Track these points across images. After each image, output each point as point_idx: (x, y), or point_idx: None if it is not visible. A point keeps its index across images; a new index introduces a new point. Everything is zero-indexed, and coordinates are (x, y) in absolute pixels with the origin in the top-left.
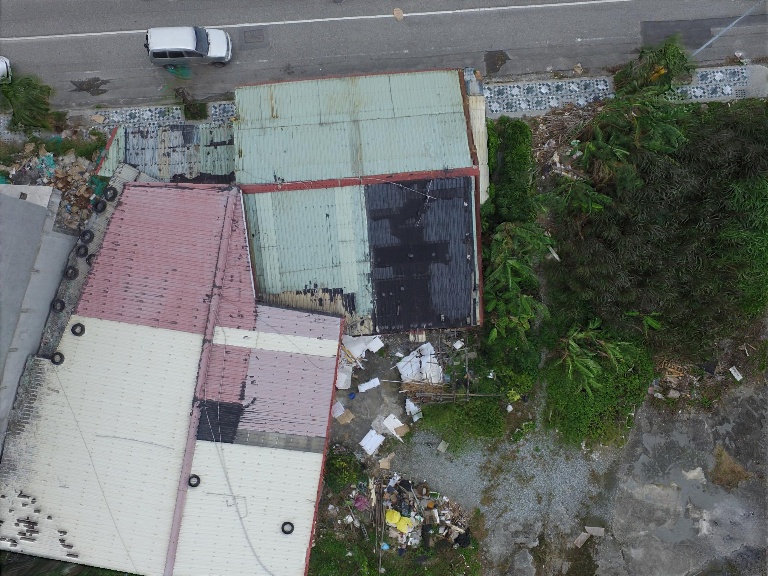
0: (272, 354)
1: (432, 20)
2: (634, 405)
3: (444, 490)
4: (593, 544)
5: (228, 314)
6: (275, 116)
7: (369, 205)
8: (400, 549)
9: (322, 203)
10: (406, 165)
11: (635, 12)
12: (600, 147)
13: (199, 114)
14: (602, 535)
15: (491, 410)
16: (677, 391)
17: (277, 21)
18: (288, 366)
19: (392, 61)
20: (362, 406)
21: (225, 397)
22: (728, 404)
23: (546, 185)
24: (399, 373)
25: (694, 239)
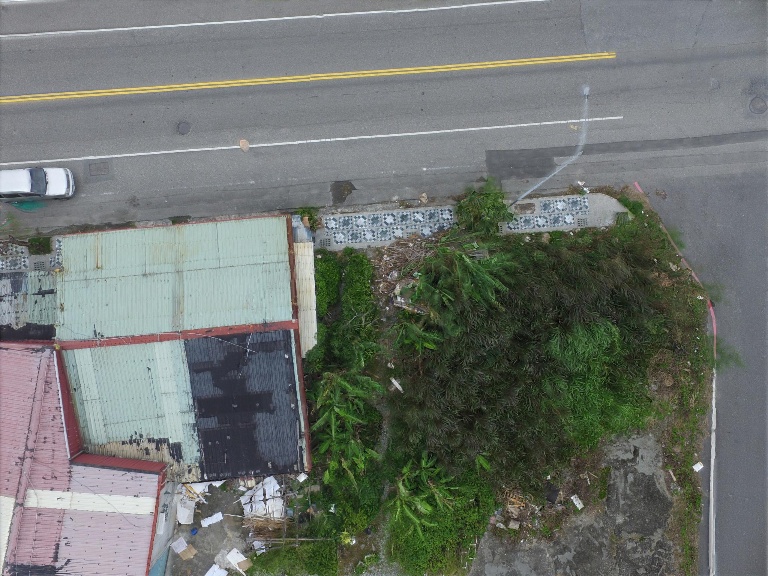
0: (87, 514)
1: (278, 151)
2: (476, 536)
3: None
4: None
5: (41, 476)
6: (100, 267)
7: (190, 358)
8: None
9: (143, 357)
10: (226, 319)
11: (480, 141)
12: (429, 290)
13: (42, 249)
14: None
15: (324, 551)
16: (517, 522)
17: (122, 154)
18: (103, 526)
19: (238, 192)
20: (205, 541)
21: (37, 560)
22: (569, 533)
23: (390, 316)
24: (242, 507)
25: (521, 382)
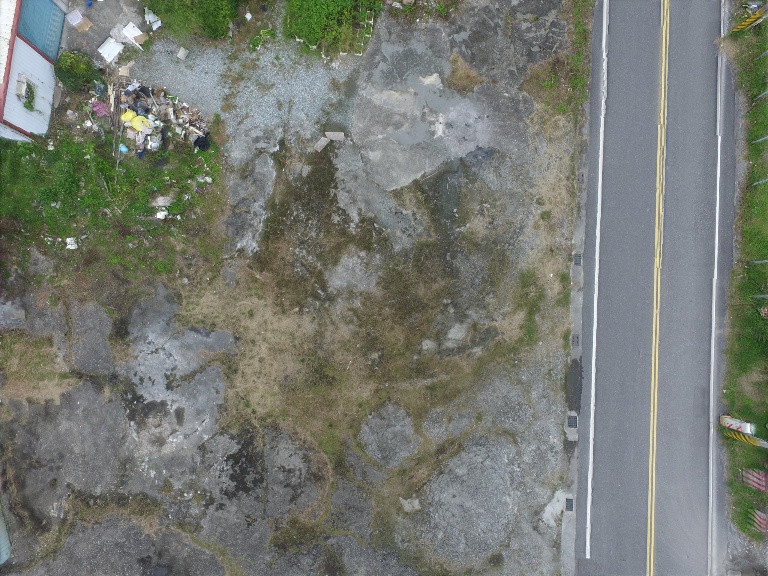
0: None
1: None
2: (372, 13)
3: (184, 97)
4: (333, 148)
5: None
6: None
7: None
8: (140, 152)
9: None
10: None
11: None
12: None
13: None
14: (341, 139)
15: None
16: None
17: None
18: None
19: None
20: (101, 14)
21: None
22: (465, 13)
23: None
24: None
25: None
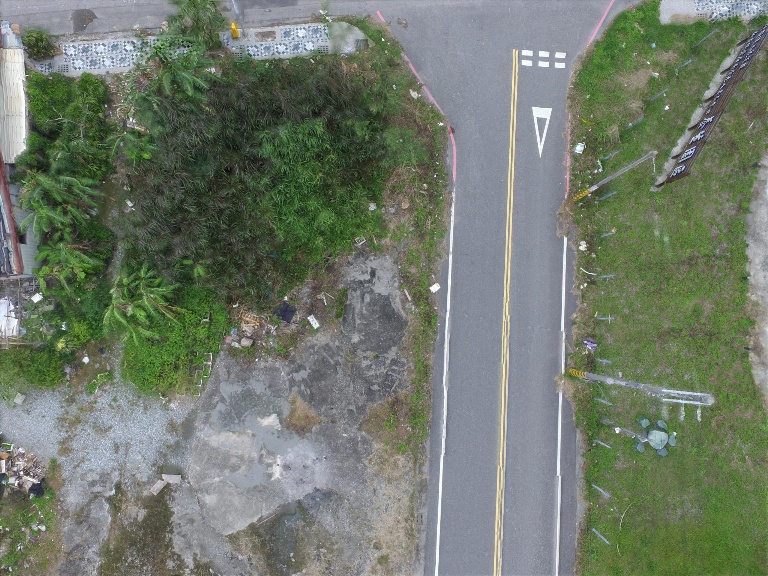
0: None
1: None
2: (210, 354)
3: (21, 442)
4: (169, 491)
5: None
6: None
7: None
8: None
9: None
10: None
11: None
12: None
13: None
14: (178, 482)
15: (41, 359)
16: (249, 339)
17: None
18: None
19: None
20: None
21: None
22: (305, 352)
23: None
24: None
25: None
